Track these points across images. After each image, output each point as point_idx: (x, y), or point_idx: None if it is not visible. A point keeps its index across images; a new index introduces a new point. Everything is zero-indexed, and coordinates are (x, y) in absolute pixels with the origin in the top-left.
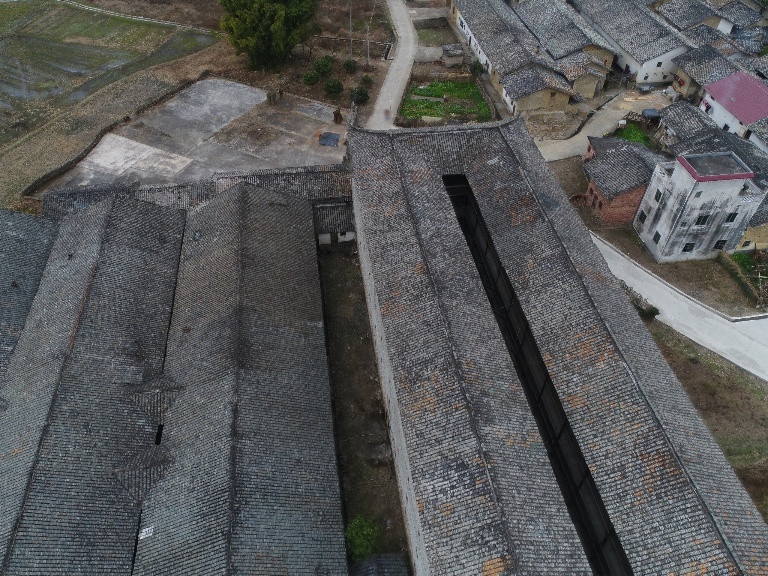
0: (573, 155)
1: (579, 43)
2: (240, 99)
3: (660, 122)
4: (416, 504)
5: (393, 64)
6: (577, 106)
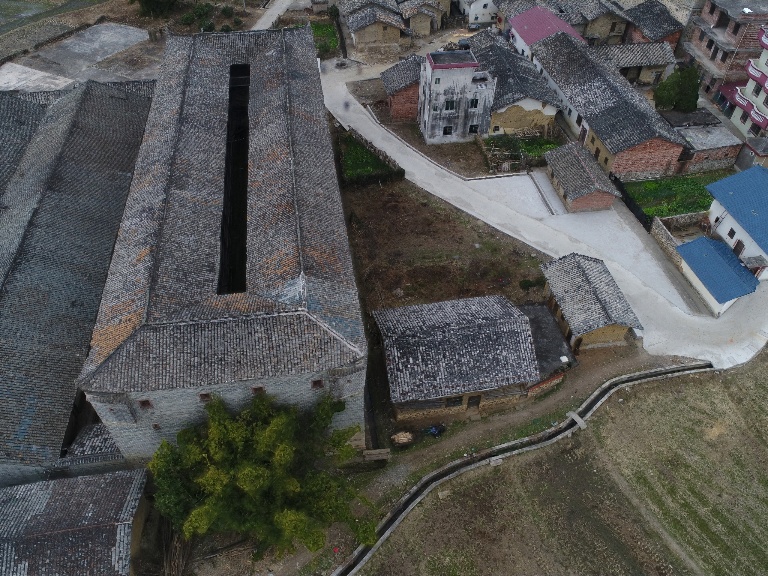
0: None
1: None
2: (127, 37)
3: None
4: None
5: (268, 11)
6: (409, 39)
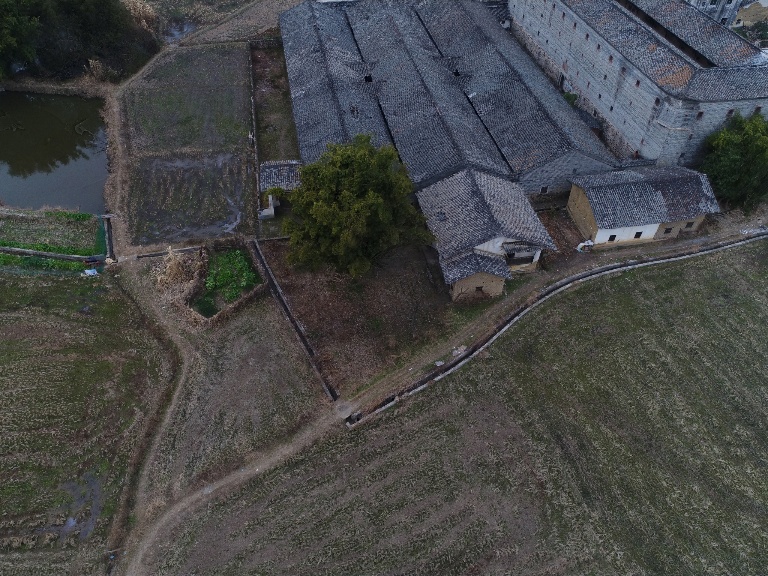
0: None
1: None
2: None
3: None
4: (605, 60)
5: None
6: None
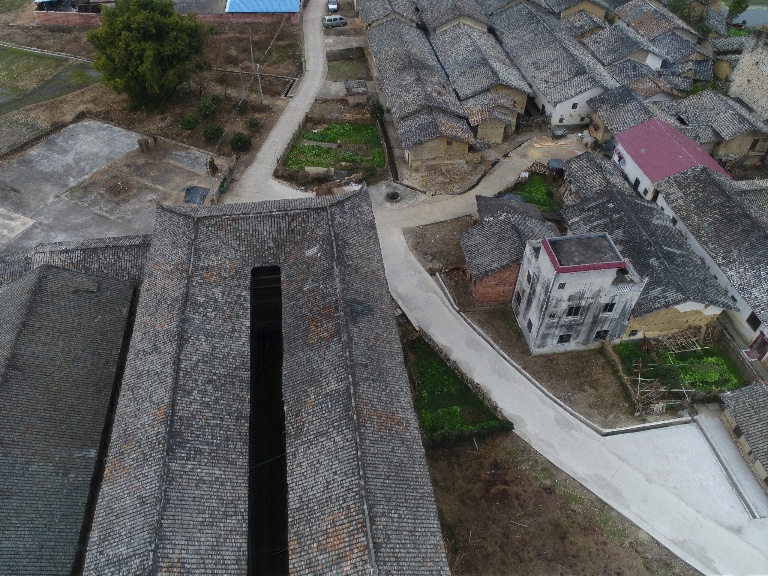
0: (463, 214)
1: (487, 82)
2: (111, 146)
3: (565, 175)
4: None
5: (291, 103)
6: (479, 154)
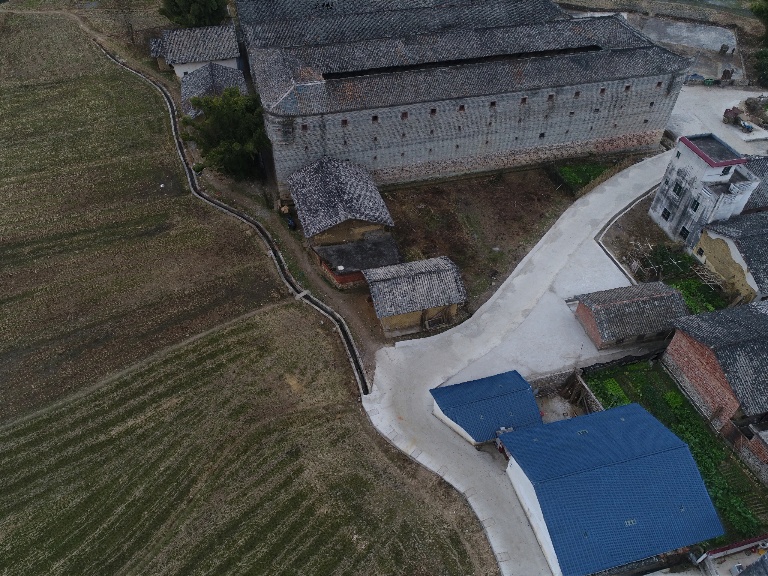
0: None
1: None
2: (713, 43)
3: None
4: None
5: None
6: None
